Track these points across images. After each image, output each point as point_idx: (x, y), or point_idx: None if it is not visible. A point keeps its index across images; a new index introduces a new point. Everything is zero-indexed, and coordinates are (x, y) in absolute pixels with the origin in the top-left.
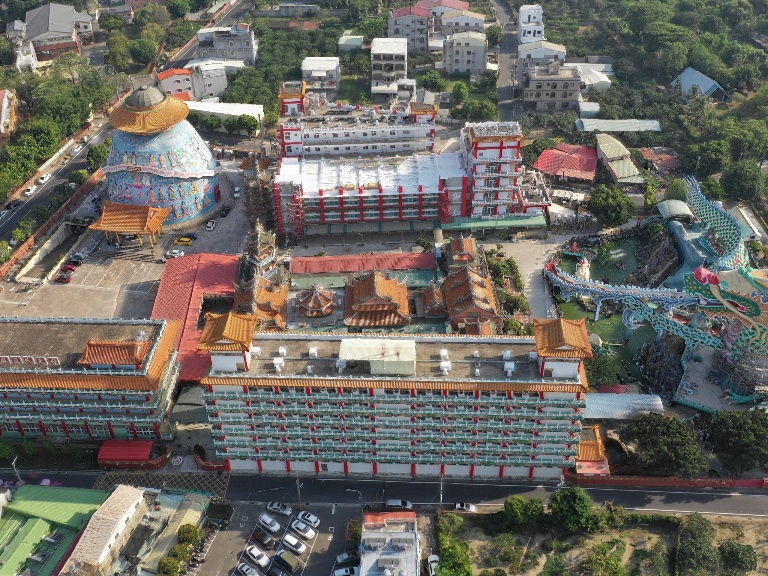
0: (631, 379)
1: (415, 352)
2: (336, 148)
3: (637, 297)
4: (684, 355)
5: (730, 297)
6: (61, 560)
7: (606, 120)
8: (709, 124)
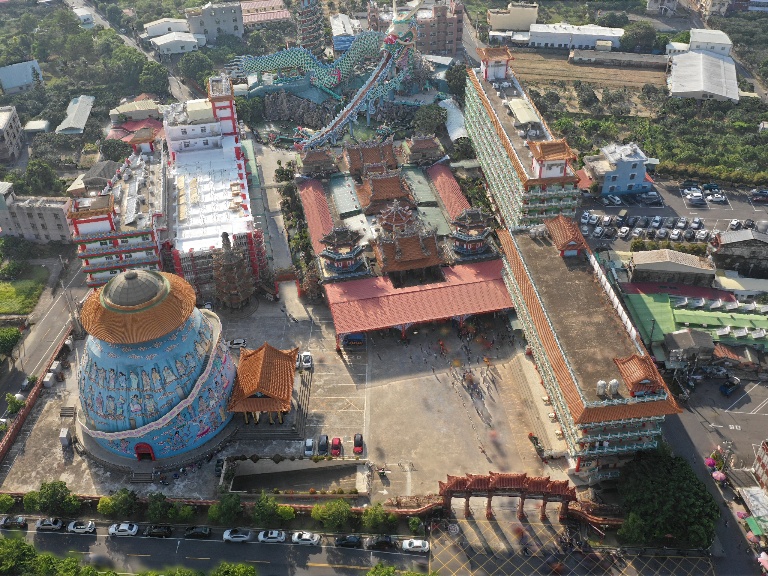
0: None
1: None
2: None
3: None
4: None
5: None
6: (693, 297)
7: (68, 118)
8: (120, 65)
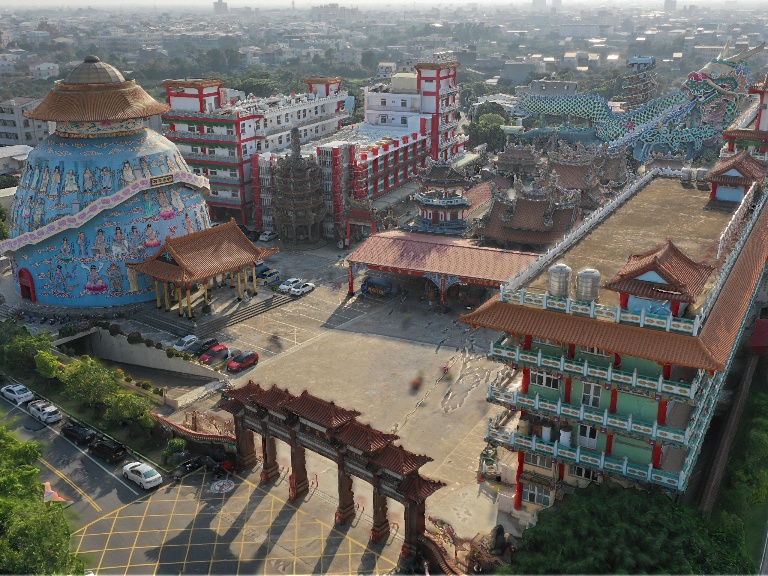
0: None
1: None
2: (279, 141)
3: (653, 128)
4: None
5: (721, 81)
6: None
7: None
8: None
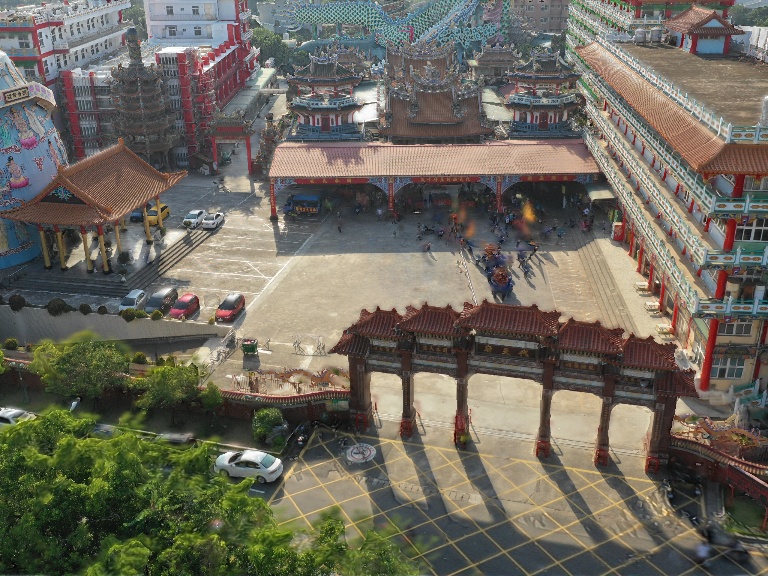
0: None
1: None
2: (75, 57)
3: (447, 27)
4: None
5: None
6: None
7: None
8: None
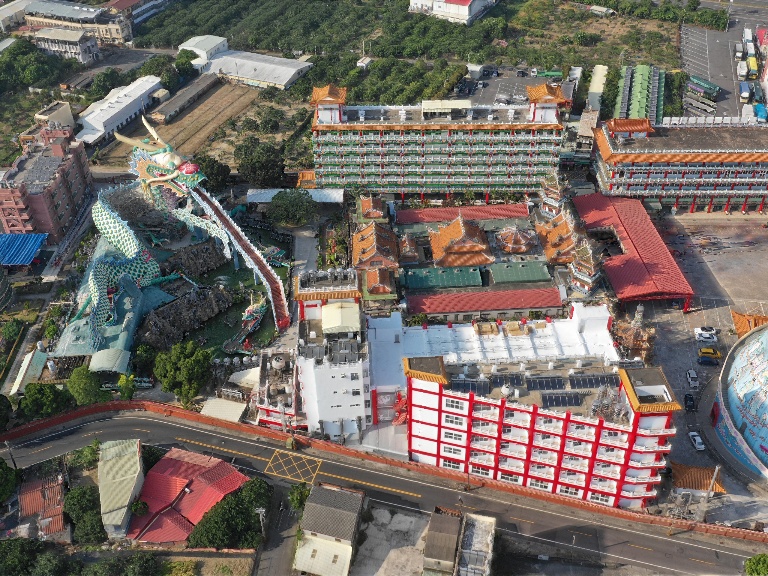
0: (252, 240)
1: (423, 119)
2: None
3: None
4: (204, 240)
5: None
6: None
7: None
8: None
